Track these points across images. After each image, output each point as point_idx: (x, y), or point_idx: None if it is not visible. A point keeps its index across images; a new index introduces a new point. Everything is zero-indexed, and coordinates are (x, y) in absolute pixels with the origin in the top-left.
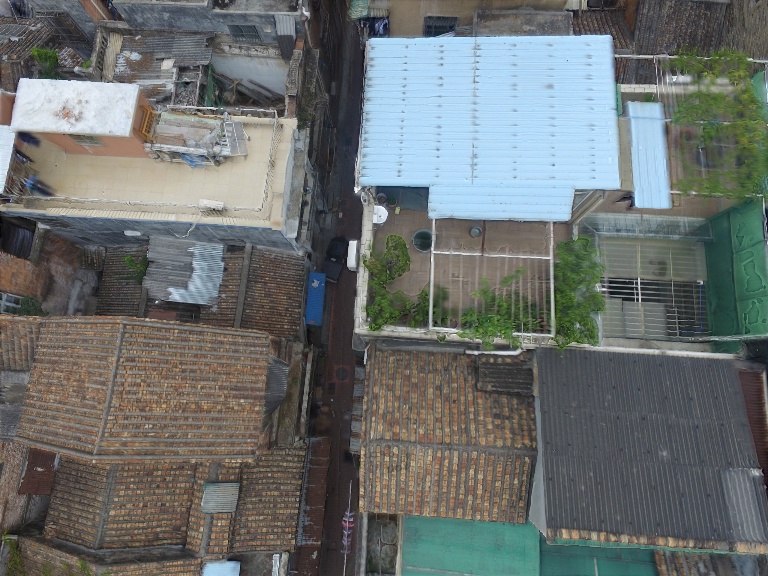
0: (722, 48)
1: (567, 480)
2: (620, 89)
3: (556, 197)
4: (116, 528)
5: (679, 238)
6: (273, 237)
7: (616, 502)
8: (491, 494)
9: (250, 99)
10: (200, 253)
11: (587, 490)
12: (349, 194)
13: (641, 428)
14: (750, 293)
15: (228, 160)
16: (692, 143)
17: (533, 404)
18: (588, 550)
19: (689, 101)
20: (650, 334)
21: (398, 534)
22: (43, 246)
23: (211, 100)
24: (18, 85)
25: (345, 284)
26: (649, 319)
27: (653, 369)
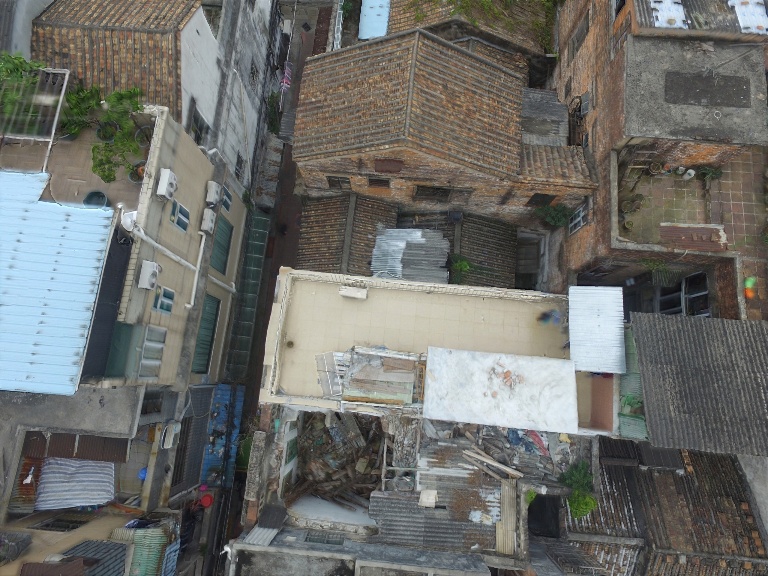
0: None
1: None
2: None
3: None
4: None
5: None
6: None
7: None
8: (86, 4)
9: (364, 496)
10: None
11: None
12: None
13: None
14: None
15: None
16: None
17: None
18: None
19: None
20: None
21: None
22: None
23: None
24: None
25: None
26: None
27: None
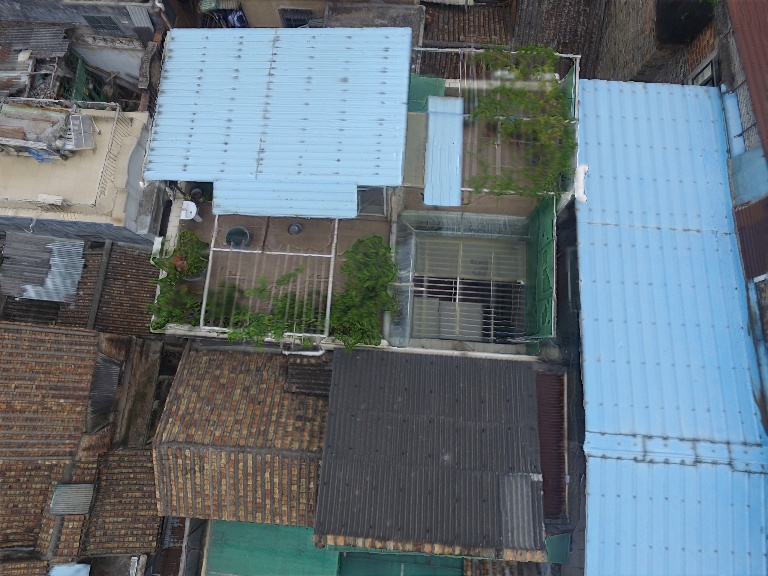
0: (602, 45)
1: (342, 485)
2: (444, 84)
3: (342, 193)
4: None
5: (497, 237)
6: (124, 233)
7: (388, 508)
8: (288, 498)
9: (133, 93)
10: (59, 249)
11: (361, 495)
12: None
13: (426, 431)
14: (543, 293)
15: (76, 154)
16: (488, 139)
17: None
18: (397, 556)
19: (490, 96)
20: (464, 335)
21: (206, 538)
22: None
23: (83, 93)
24: None
25: None
26: (465, 319)
27: (449, 371)
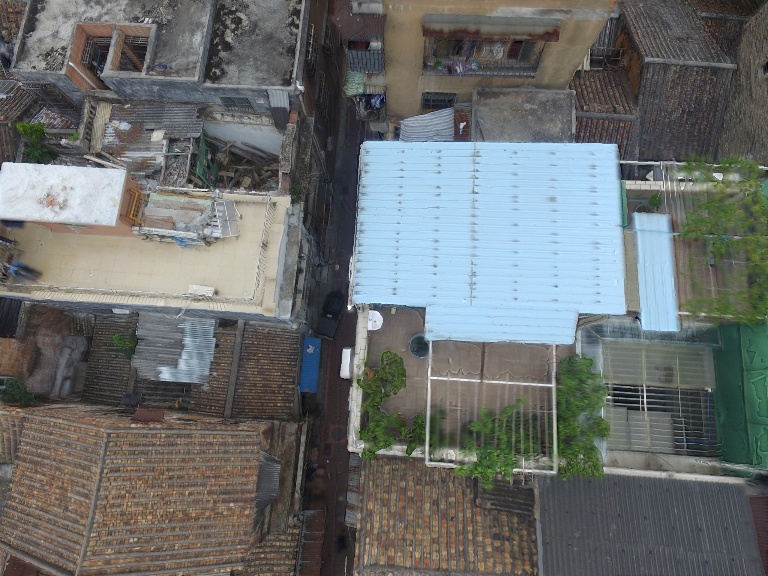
0: (728, 114)
1: None
2: (625, 186)
3: (559, 319)
4: None
5: (686, 345)
6: (266, 318)
7: None
8: None
9: (244, 159)
10: (191, 329)
11: None
12: (346, 245)
13: (648, 562)
14: (762, 418)
15: (219, 240)
16: (701, 259)
17: (534, 523)
18: None
19: (698, 213)
20: (656, 446)
21: None
22: (29, 321)
23: (203, 165)
24: (1, 170)
25: (341, 340)
26: (655, 430)
27: (660, 494)
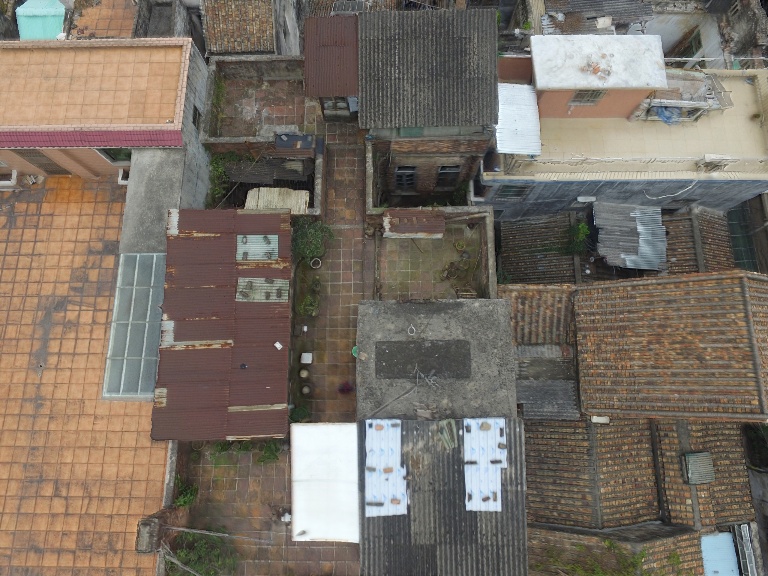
0: None
1: None
2: None
3: None
4: (609, 506)
5: None
6: (748, 193)
7: None
8: None
9: None
10: (642, 217)
11: None
12: None
13: None
14: None
15: (705, 115)
16: None
17: None
18: None
19: None
20: None
21: None
22: None
23: None
24: (531, 42)
25: None
26: None
27: None
